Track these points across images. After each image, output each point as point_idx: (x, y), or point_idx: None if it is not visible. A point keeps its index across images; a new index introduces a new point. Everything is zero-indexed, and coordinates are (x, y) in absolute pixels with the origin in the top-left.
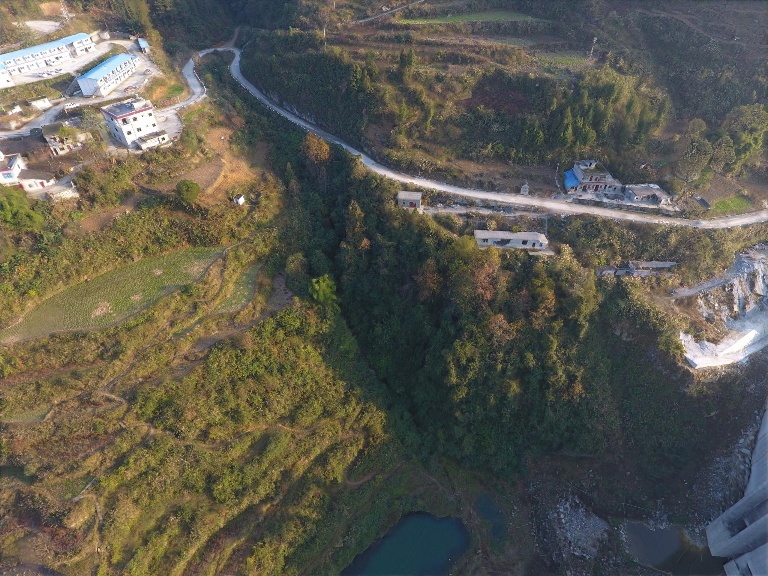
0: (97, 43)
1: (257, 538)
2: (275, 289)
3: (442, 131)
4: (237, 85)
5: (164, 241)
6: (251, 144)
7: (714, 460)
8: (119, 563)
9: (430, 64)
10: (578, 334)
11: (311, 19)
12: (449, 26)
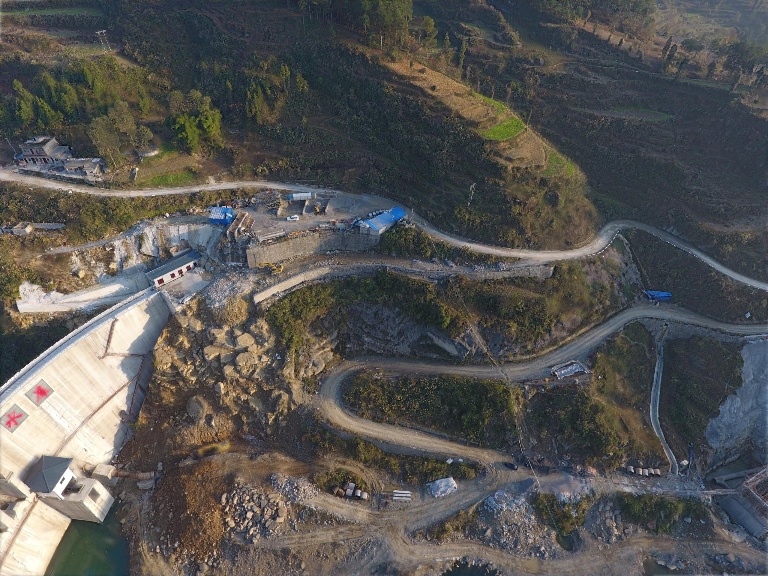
0: None
1: None
2: None
3: None
4: None
5: None
6: None
7: None
8: None
9: None
10: None
11: None
12: (8, 18)
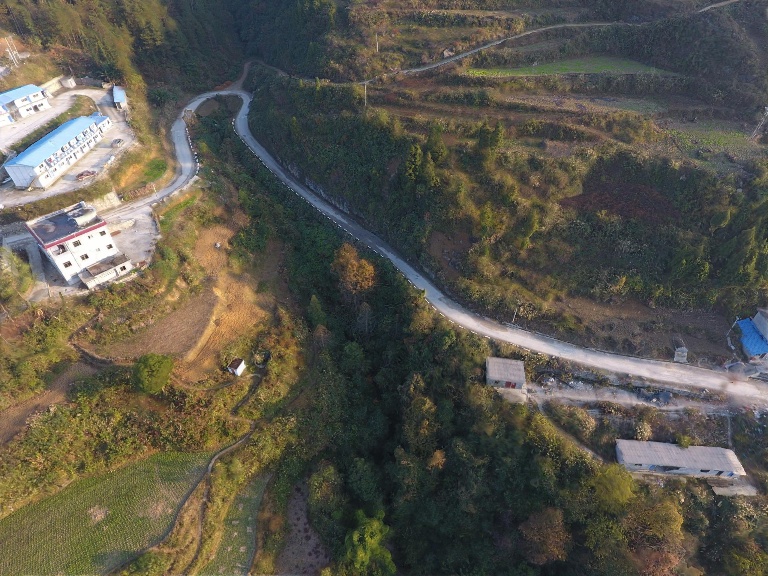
0: (56, 95)
1: None
2: (290, 528)
3: (544, 249)
4: (243, 149)
5: (113, 450)
6: (259, 249)
7: None
8: None
9: (518, 139)
10: None
11: (345, 66)
12: (540, 81)
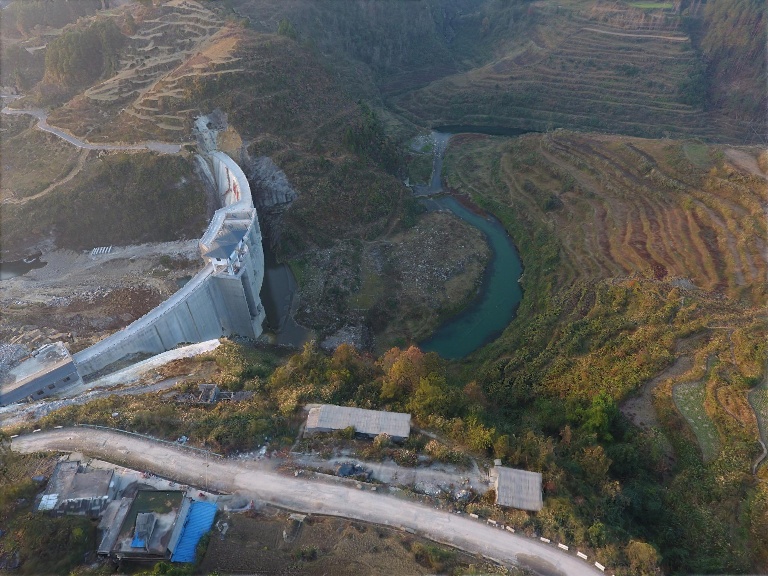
0: None
1: (561, 319)
2: None
3: None
4: None
5: None
6: None
7: None
8: (632, 291)
9: None
10: None
11: None
12: None
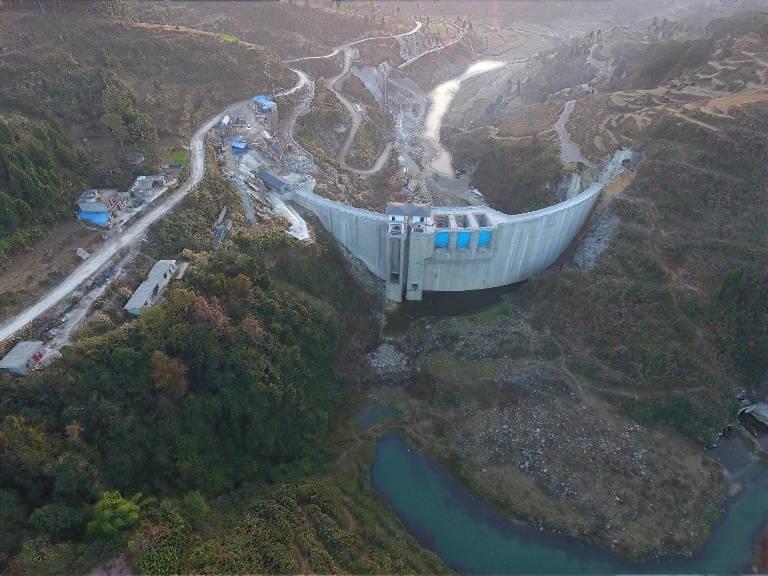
0: None
1: None
2: None
3: None
4: None
5: None
6: None
7: (352, 273)
8: None
9: None
10: (269, 284)
11: None
12: None
